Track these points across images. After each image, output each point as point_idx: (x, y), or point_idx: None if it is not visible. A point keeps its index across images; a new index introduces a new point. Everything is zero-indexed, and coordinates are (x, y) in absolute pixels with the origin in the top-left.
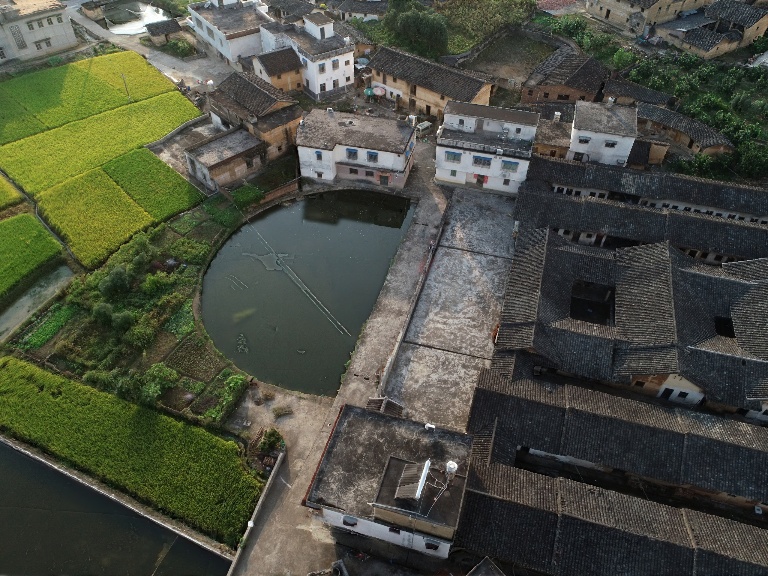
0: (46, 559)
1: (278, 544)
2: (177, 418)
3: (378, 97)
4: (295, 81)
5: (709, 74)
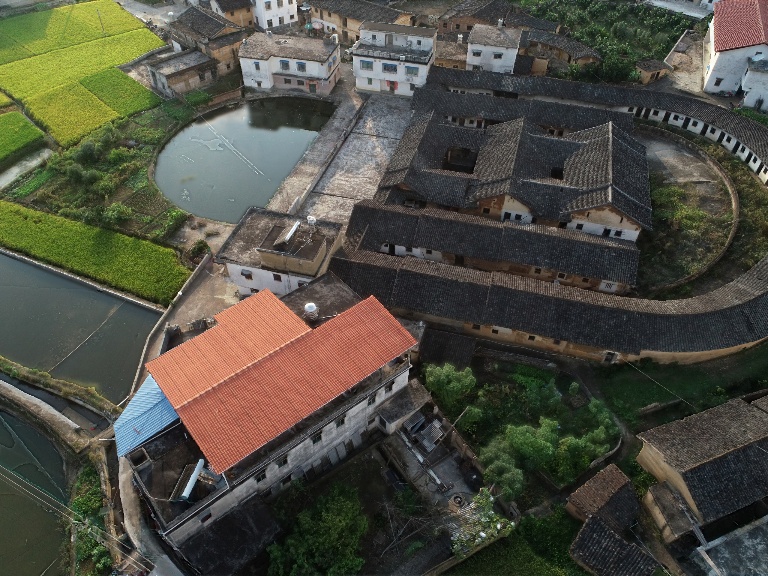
0: (28, 313)
1: (199, 305)
2: (130, 236)
3: (317, 31)
4: (247, 19)
5: (598, 10)
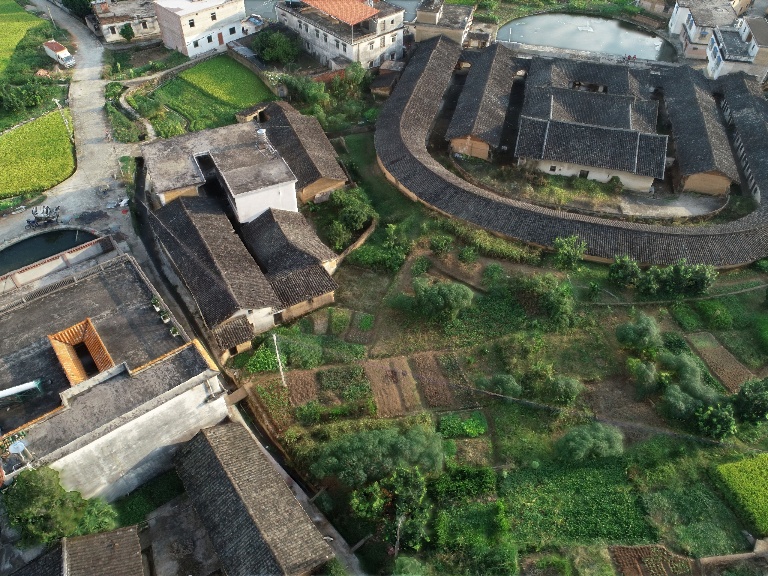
0: None
1: None
2: None
3: None
4: None
5: None
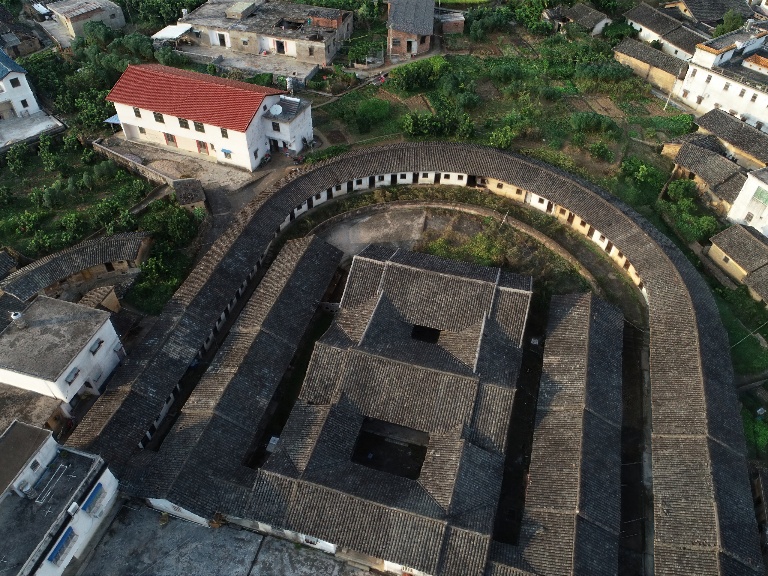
0: None
1: None
2: None
3: None
4: None
5: None
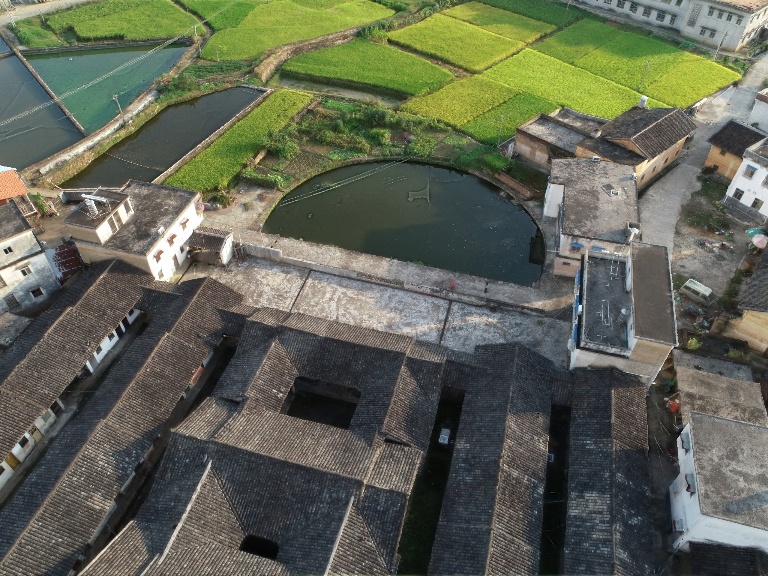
0: None
1: None
2: None
3: (758, 248)
4: None
5: None
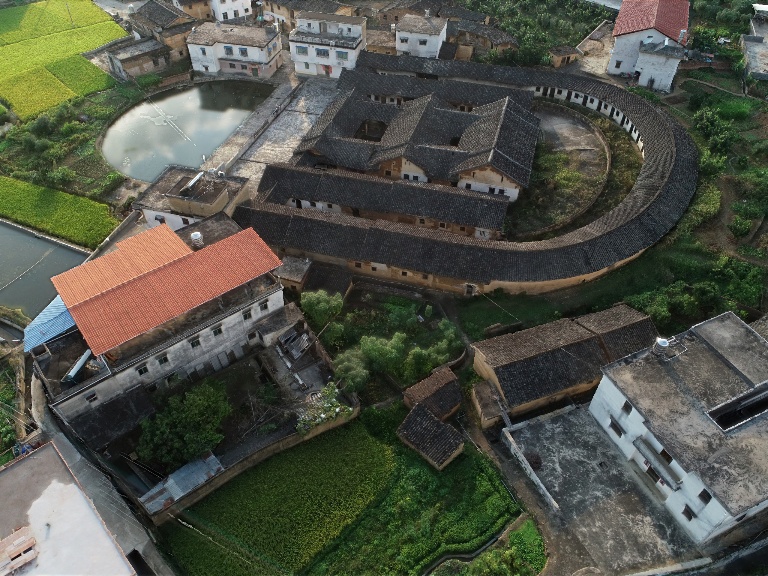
0: None
1: None
2: (71, 194)
3: None
4: (204, 12)
5: (528, 3)
